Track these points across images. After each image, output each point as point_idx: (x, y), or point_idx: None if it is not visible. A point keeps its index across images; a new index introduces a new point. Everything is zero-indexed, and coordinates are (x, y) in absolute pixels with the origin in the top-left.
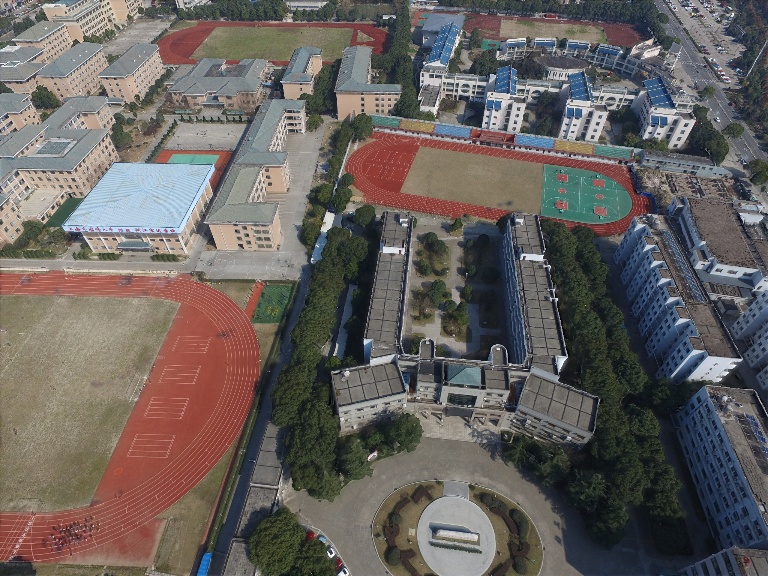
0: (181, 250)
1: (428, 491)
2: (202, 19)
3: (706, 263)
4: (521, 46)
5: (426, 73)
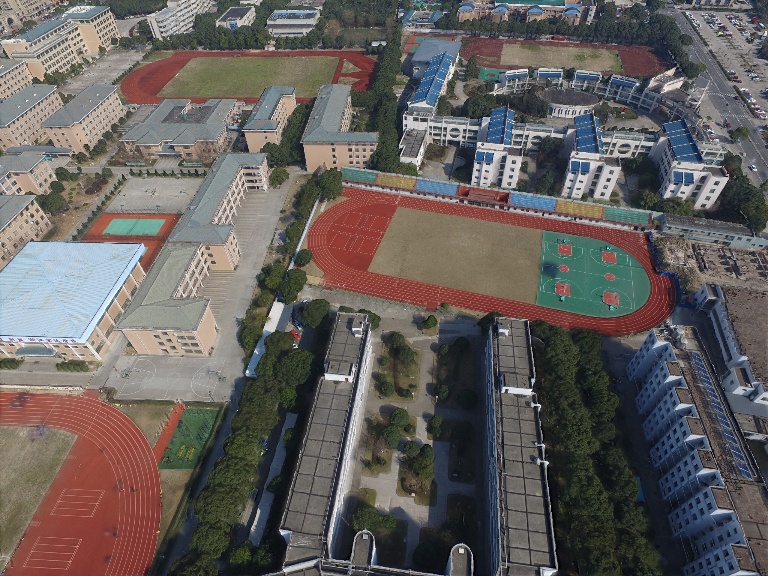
0: (93, 356)
1: None
2: (179, 49)
3: (748, 389)
4: (522, 78)
5: (409, 116)
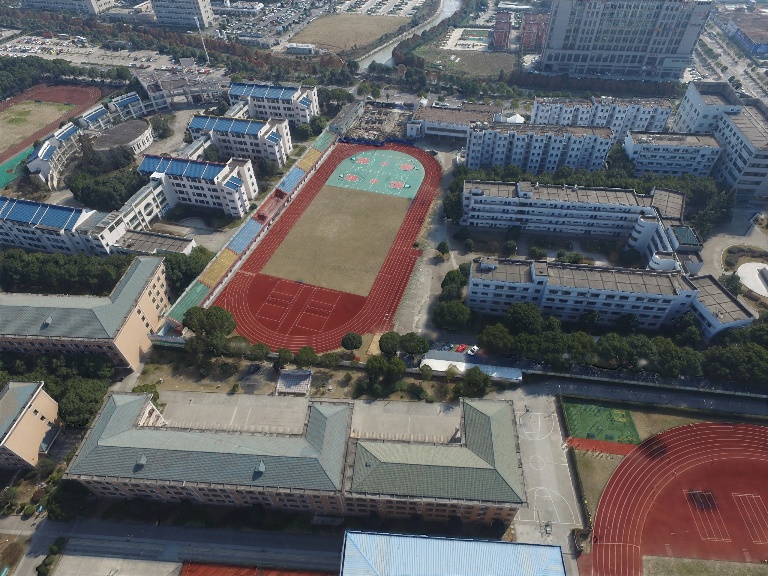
0: None
1: (746, 292)
2: None
3: None
4: None
5: (104, 231)
